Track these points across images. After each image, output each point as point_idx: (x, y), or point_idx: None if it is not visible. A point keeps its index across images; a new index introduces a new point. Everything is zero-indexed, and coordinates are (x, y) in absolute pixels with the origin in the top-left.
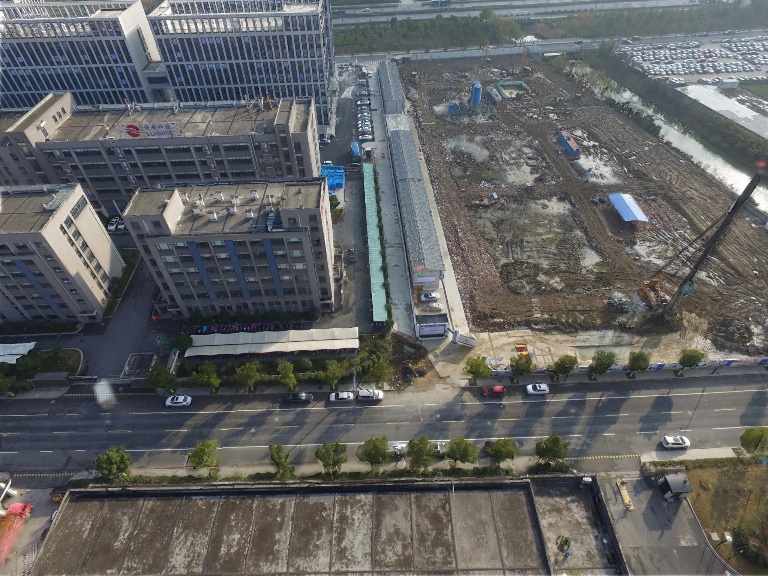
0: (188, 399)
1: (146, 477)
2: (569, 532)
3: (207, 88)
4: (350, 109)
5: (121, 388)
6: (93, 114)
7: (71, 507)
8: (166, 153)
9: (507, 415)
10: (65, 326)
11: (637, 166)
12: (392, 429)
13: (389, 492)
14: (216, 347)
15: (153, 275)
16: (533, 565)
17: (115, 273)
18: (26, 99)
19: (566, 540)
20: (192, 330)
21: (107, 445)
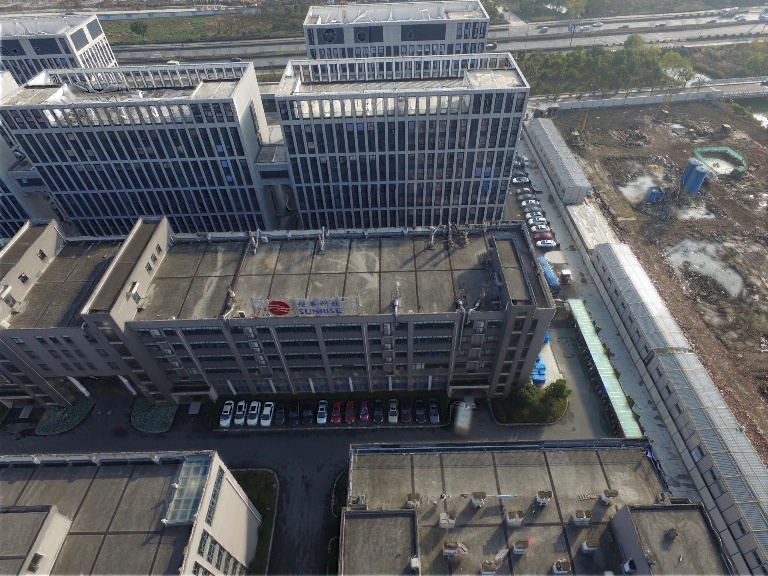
0: None
1: None
2: None
3: (342, 185)
4: None
5: None
6: (199, 248)
7: None
8: (322, 332)
9: None
10: None
11: None
12: None
13: None
14: None
15: None
16: None
17: (251, 547)
18: (95, 199)
19: None
20: None
21: None
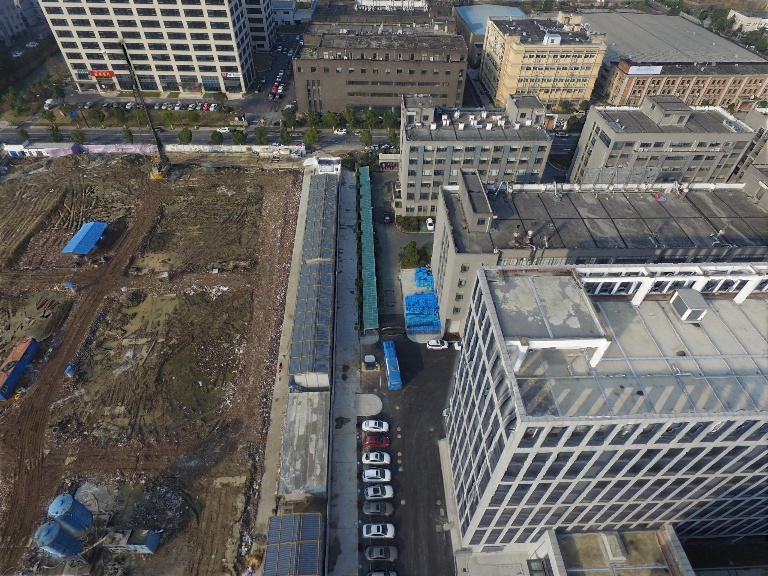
0: None
1: None
2: None
3: None
4: None
5: None
6: None
7: None
8: None
9: (300, 141)
10: None
11: None
12: None
13: None
14: None
15: None
16: None
17: None
18: None
19: None
20: None
21: None
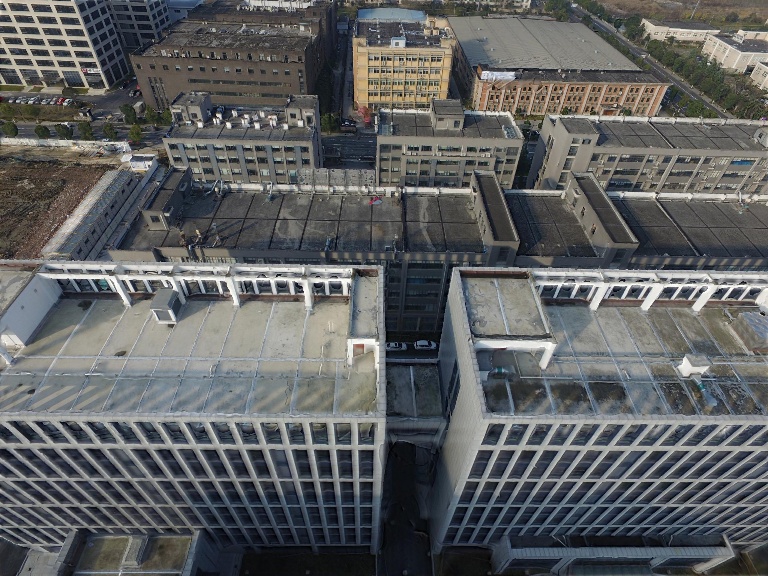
0: None
1: None
2: None
3: None
4: None
5: None
6: (453, 248)
7: None
8: None
9: None
10: None
11: None
12: None
13: None
14: None
15: None
16: None
17: None
18: None
19: None
20: None
21: None
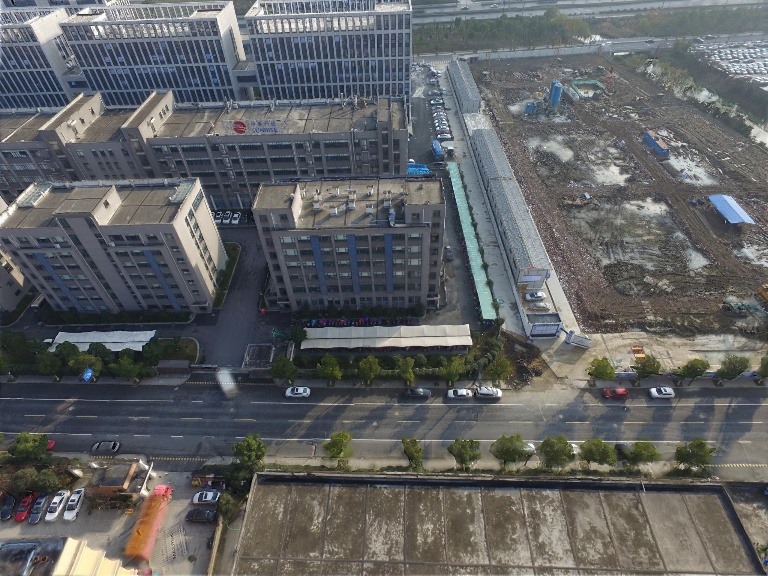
0: (308, 390)
1: (280, 465)
2: (763, 539)
3: (294, 87)
4: (424, 108)
5: (240, 378)
6: (193, 111)
7: (260, 489)
8: (268, 149)
9: (633, 418)
10: (179, 316)
11: (733, 167)
12: (516, 428)
13: (575, 489)
14: (330, 340)
15: (269, 268)
16: (746, 571)
17: (221, 266)
18: (121, 97)
19: (765, 547)
20: (301, 323)
21: (234, 432)
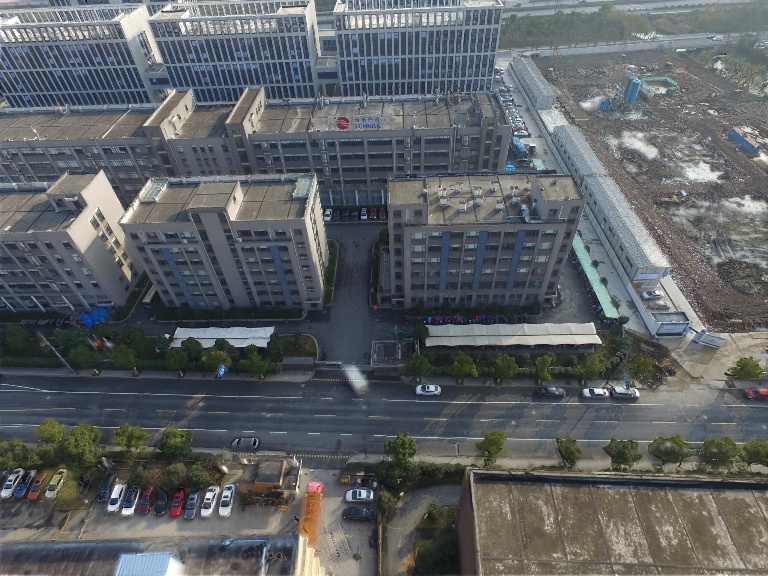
0: (439, 388)
1: (431, 464)
2: None
3: (375, 83)
4: None
5: (365, 375)
6: (284, 108)
7: (479, 488)
8: (367, 145)
9: None
10: (291, 312)
11: None
12: (661, 428)
13: None
14: (454, 338)
15: (391, 264)
16: None
17: (326, 262)
18: (201, 94)
19: None
20: (417, 320)
21: (372, 430)
